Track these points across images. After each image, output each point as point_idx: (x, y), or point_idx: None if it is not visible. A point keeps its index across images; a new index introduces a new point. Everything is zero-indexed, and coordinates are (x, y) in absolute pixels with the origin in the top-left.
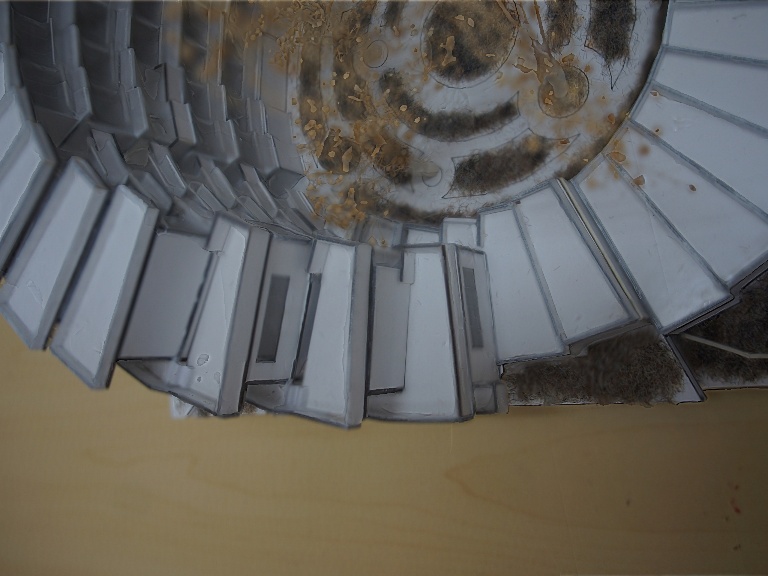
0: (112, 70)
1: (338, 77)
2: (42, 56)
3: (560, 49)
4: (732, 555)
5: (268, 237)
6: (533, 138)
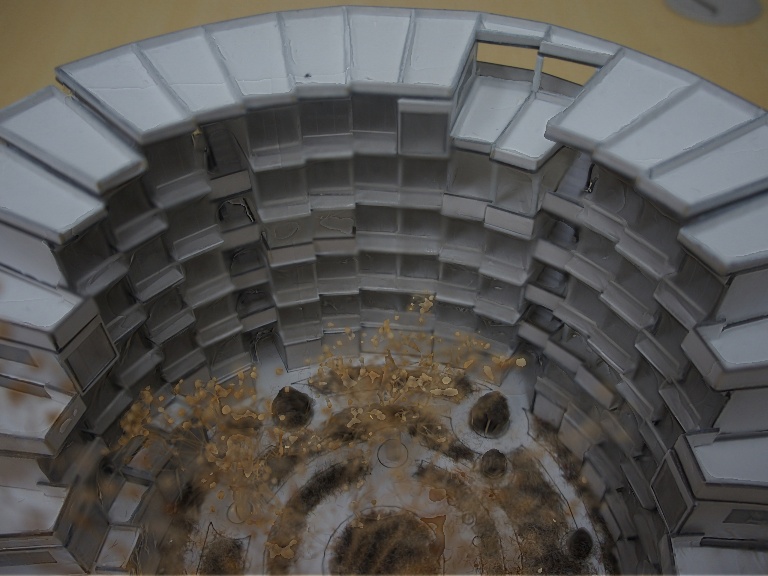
0: (324, 189)
1: None
2: (315, 125)
3: None
4: None
5: (53, 349)
6: None
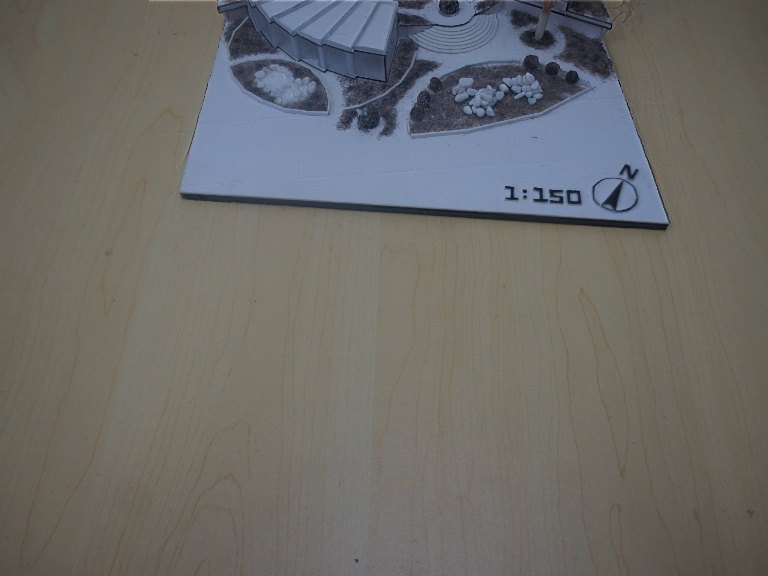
0: None
1: None
2: None
3: None
4: (157, 31)
5: None
6: None
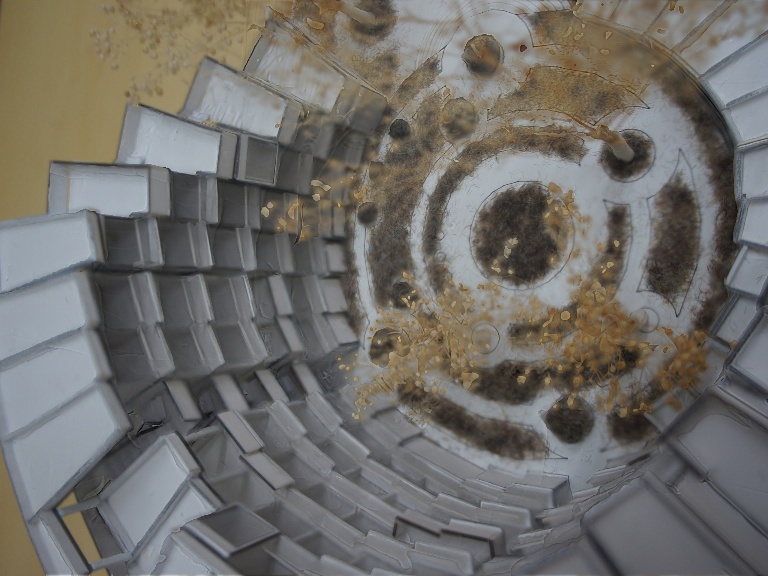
0: (384, 557)
1: (485, 388)
2: None
3: (584, 149)
4: None
5: None
6: (660, 197)
